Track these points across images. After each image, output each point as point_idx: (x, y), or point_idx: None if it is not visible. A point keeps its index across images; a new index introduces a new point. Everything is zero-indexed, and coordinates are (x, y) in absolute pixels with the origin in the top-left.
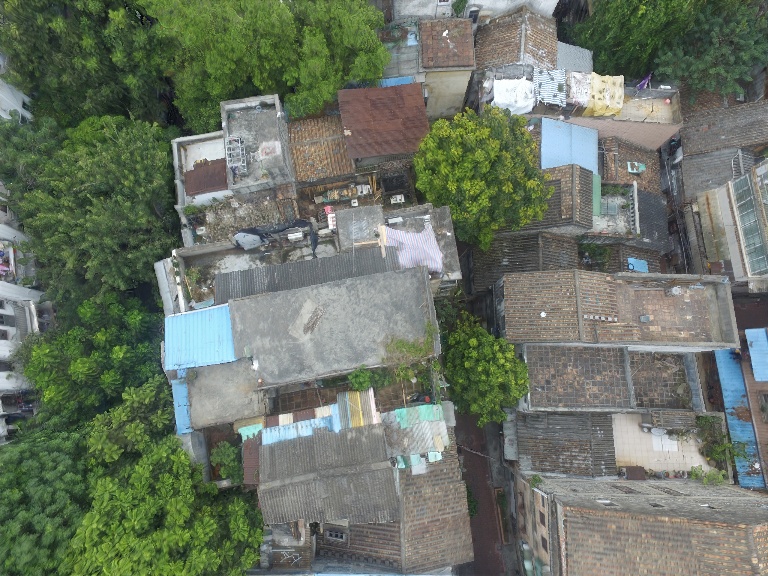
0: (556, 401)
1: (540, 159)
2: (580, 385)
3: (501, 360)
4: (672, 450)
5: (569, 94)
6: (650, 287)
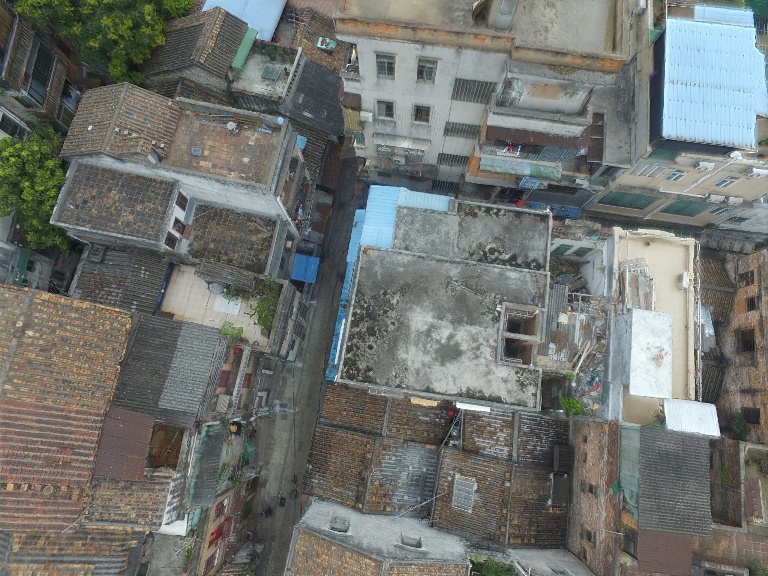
0: (85, 221)
1: (205, 6)
2: (117, 211)
3: (5, 152)
4: (232, 313)
5: None
6: (217, 123)
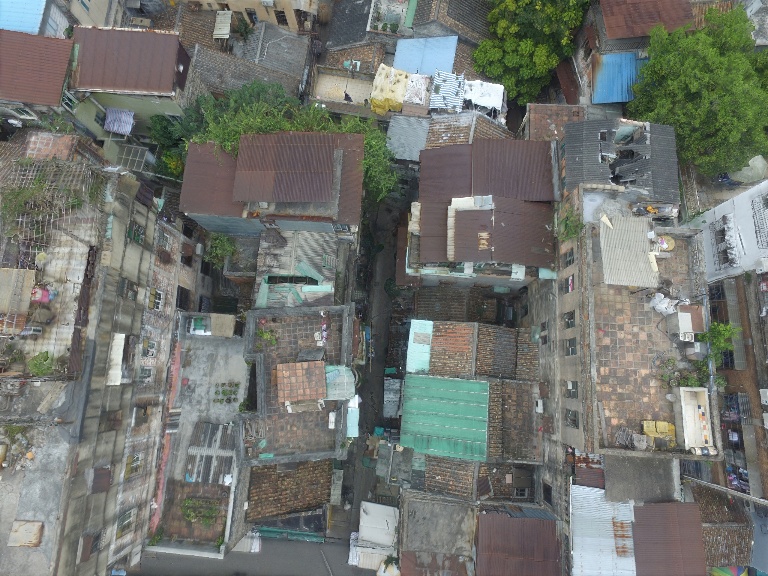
0: None
1: None
2: None
3: None
4: None
5: (430, 81)
6: None
